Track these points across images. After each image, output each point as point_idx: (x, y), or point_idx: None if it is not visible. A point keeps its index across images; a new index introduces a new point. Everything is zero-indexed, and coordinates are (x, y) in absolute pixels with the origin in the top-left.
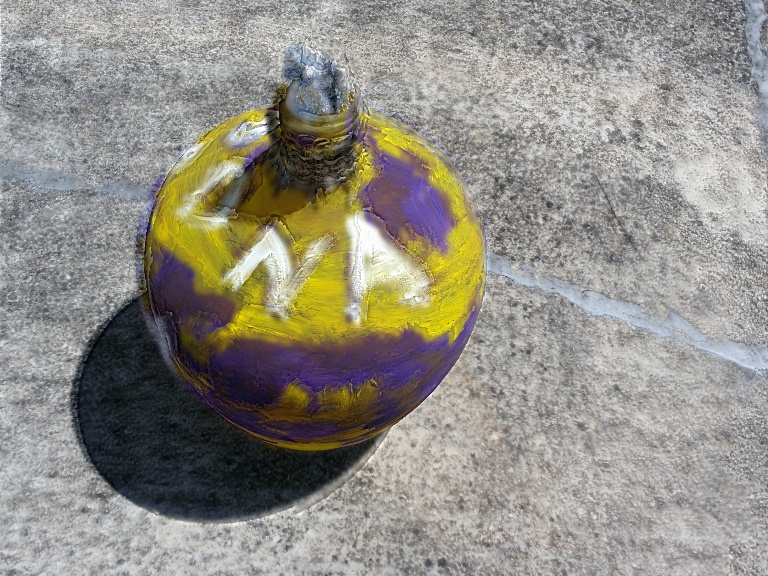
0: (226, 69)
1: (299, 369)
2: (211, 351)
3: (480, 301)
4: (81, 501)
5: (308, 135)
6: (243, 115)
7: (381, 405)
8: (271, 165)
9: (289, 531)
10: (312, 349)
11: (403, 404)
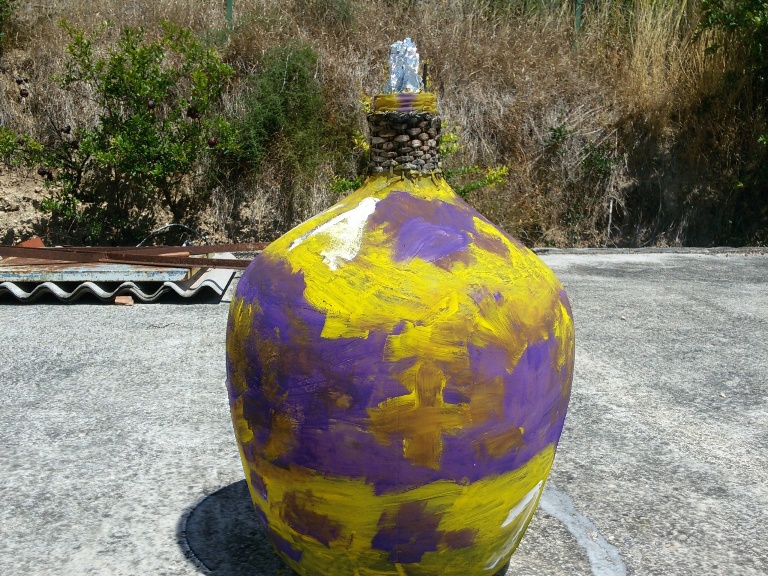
0: (698, 465)
1: None
2: None
3: (386, 346)
4: (199, 484)
5: None
6: None
7: (248, 359)
8: None
9: (183, 572)
10: None
11: (265, 391)
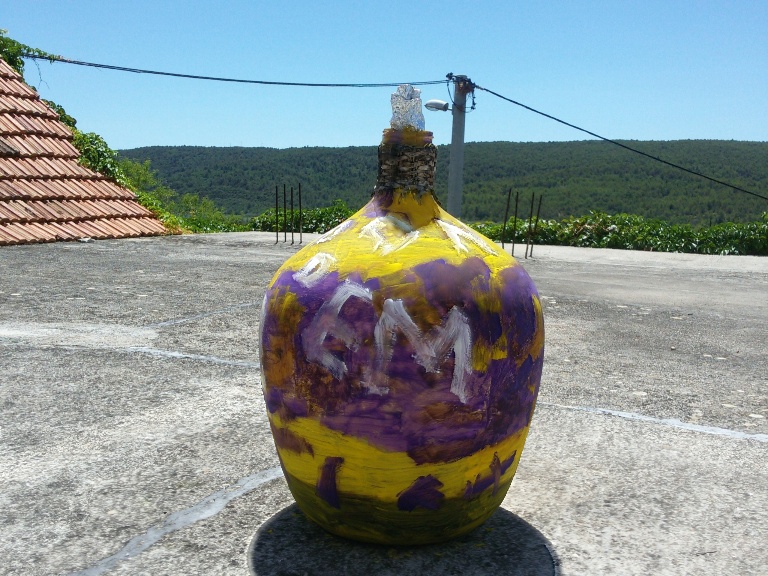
0: None
1: (528, 286)
2: (497, 304)
3: None
4: None
5: (428, 144)
6: (294, 257)
7: None
8: (397, 205)
9: (569, 549)
10: (520, 270)
11: None
